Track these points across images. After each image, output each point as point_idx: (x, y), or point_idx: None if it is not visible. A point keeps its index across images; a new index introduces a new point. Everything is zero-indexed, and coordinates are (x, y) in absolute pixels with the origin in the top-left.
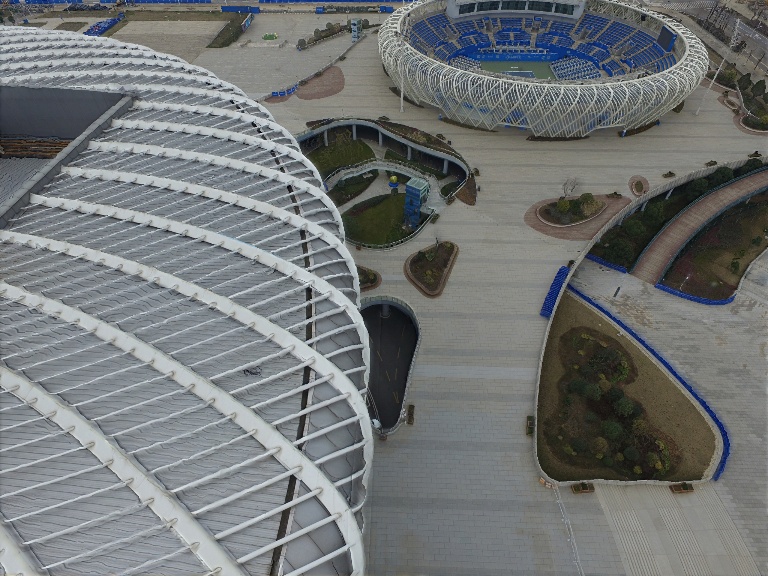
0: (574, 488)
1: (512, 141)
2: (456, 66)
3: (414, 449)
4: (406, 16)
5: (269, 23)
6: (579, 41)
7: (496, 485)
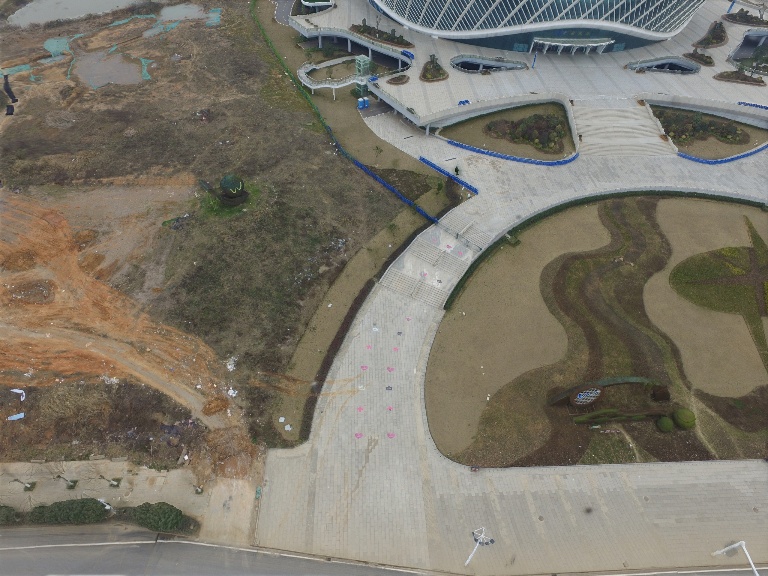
0: (639, 100)
1: None
2: None
3: (626, 73)
4: None
5: None
6: None
7: None
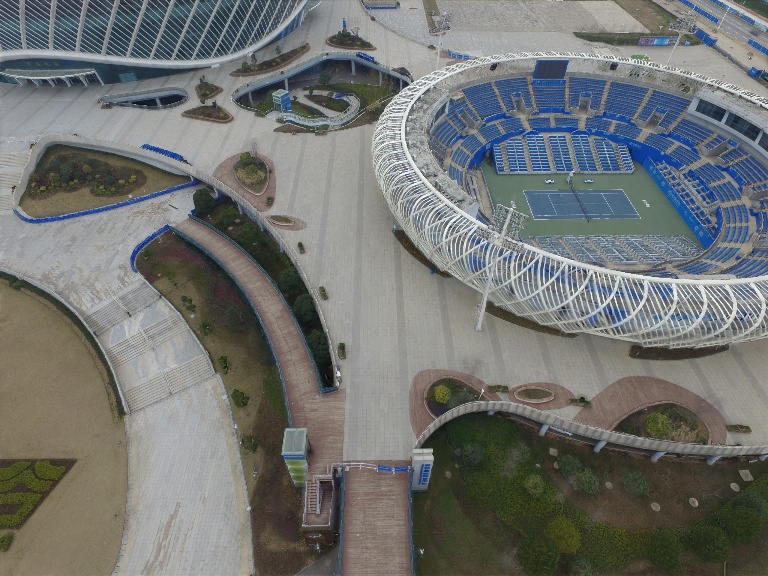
0: None
1: None
2: (582, 140)
3: (89, 109)
4: (609, 64)
5: (683, 54)
6: (751, 248)
7: (56, 127)
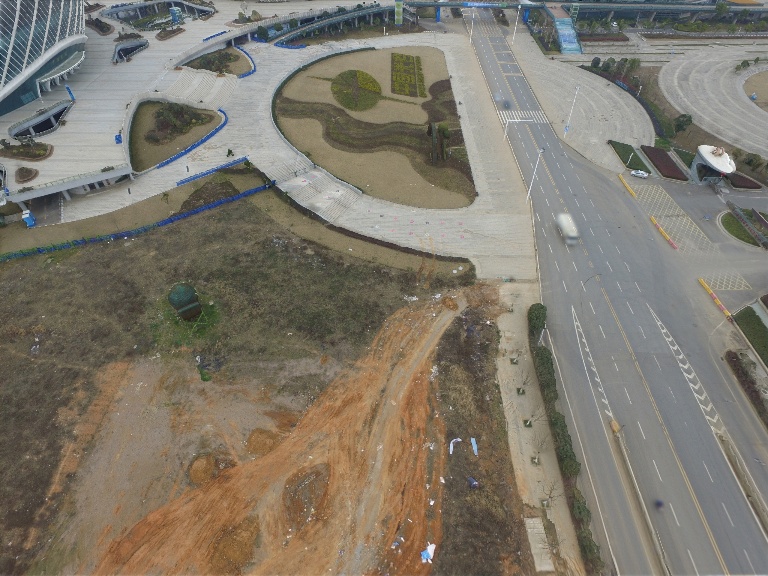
0: (174, 68)
1: (247, 3)
2: None
3: None
4: None
5: None
6: None
7: None
